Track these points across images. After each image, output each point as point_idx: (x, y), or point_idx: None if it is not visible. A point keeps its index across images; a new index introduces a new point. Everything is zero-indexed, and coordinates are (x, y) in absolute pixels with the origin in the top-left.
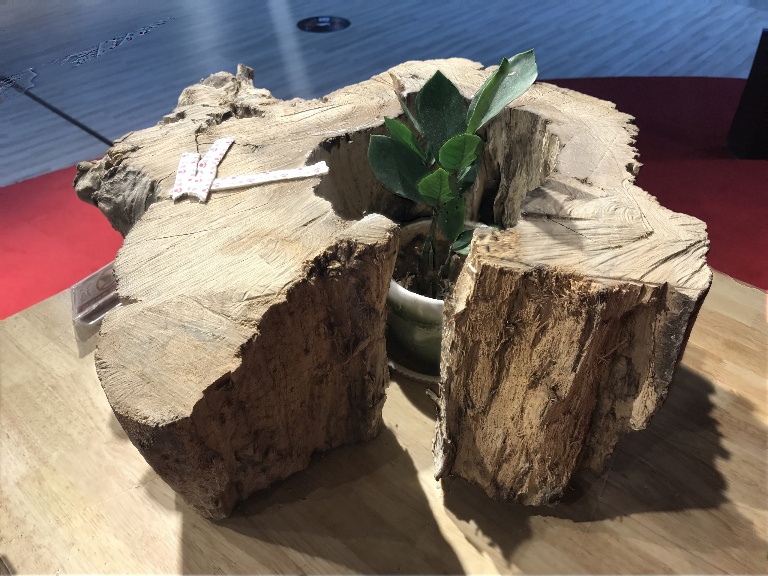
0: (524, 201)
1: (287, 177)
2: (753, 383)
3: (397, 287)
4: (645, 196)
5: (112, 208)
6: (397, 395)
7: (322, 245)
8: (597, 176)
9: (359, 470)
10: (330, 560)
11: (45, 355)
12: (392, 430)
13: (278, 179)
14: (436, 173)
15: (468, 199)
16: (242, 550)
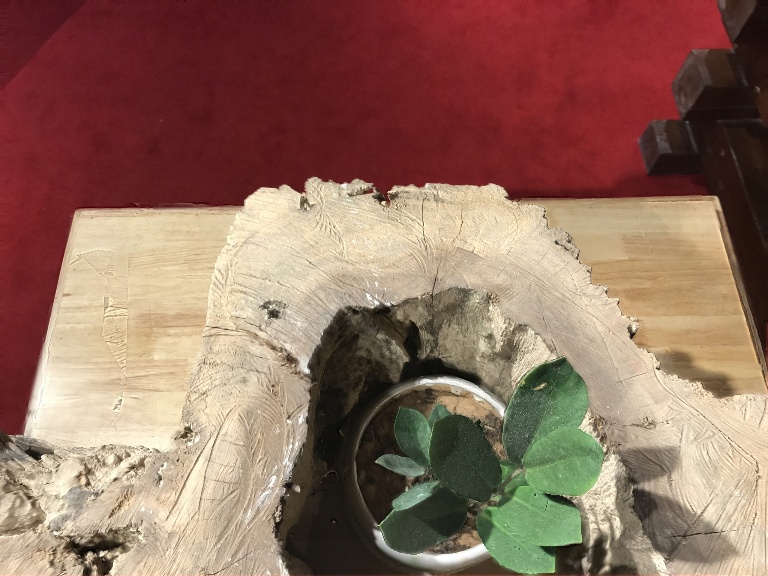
0: (651, 535)
1: None
2: (673, 329)
3: (436, 560)
4: (695, 391)
5: None
6: None
7: None
8: (633, 390)
9: None
10: None
11: None
12: None
13: None
14: (543, 571)
15: (392, 369)
16: None
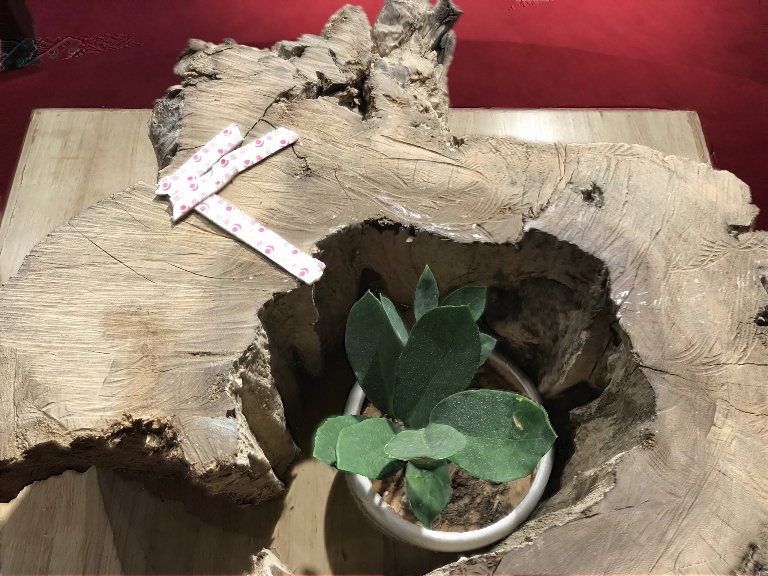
0: None
1: (268, 255)
2: None
3: None
4: None
5: (149, 135)
6: (327, 477)
7: (165, 406)
8: None
9: (223, 517)
10: (124, 572)
11: (141, 176)
12: (285, 507)
13: (259, 250)
14: (317, 449)
15: (552, 375)
16: (86, 498)
